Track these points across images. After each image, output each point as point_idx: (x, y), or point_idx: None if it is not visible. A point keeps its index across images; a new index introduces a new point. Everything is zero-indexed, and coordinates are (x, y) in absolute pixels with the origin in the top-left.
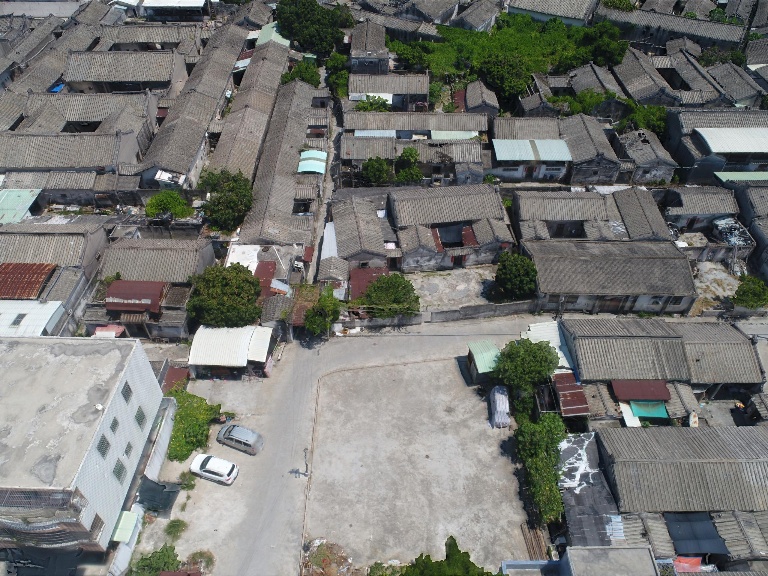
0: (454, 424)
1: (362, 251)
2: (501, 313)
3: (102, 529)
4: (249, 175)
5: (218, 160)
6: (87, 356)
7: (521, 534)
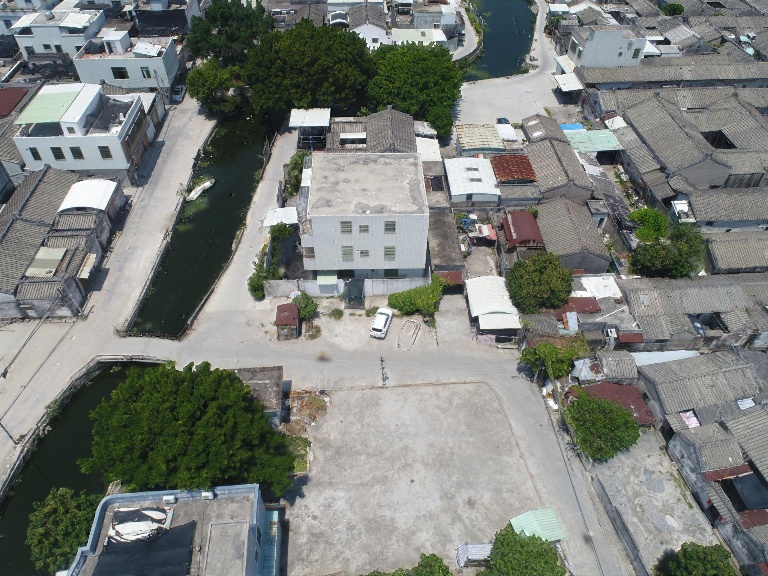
0: (454, 508)
1: (654, 383)
2: (639, 571)
3: (312, 259)
4: (726, 265)
5: (732, 235)
6: (410, 196)
7: (336, 571)
